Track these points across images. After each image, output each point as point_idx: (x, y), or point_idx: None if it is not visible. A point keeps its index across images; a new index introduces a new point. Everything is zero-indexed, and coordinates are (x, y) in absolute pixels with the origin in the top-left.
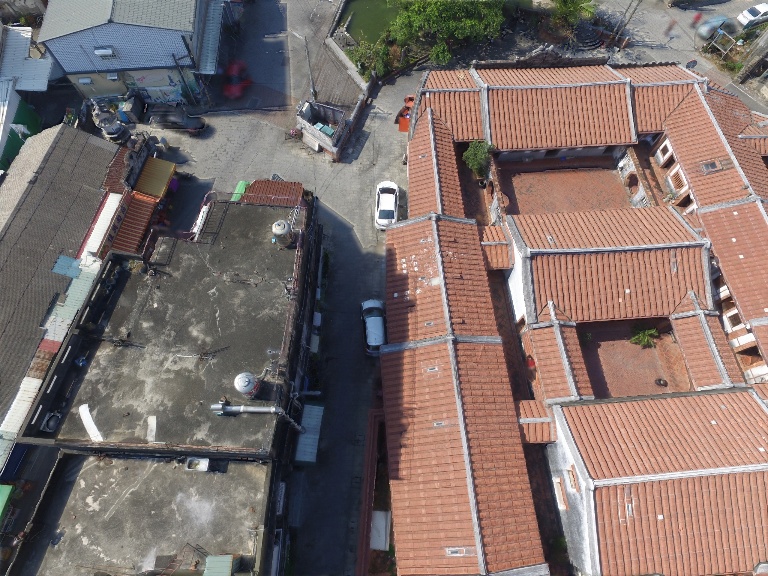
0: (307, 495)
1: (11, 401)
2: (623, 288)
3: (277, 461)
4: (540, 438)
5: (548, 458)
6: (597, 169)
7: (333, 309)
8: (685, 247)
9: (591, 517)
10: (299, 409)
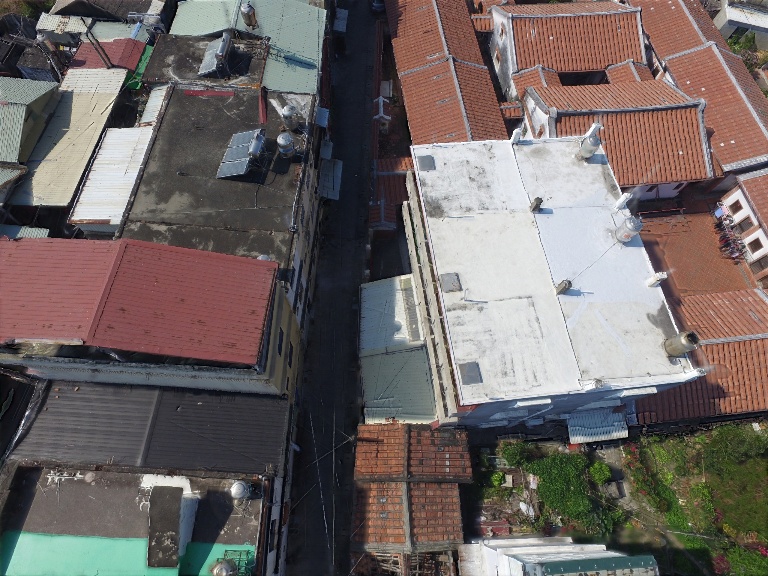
0: (339, 73)
1: (147, 9)
2: None
3: None
4: (484, 28)
5: (490, 52)
6: None
7: None
8: None
9: (511, 34)
10: None
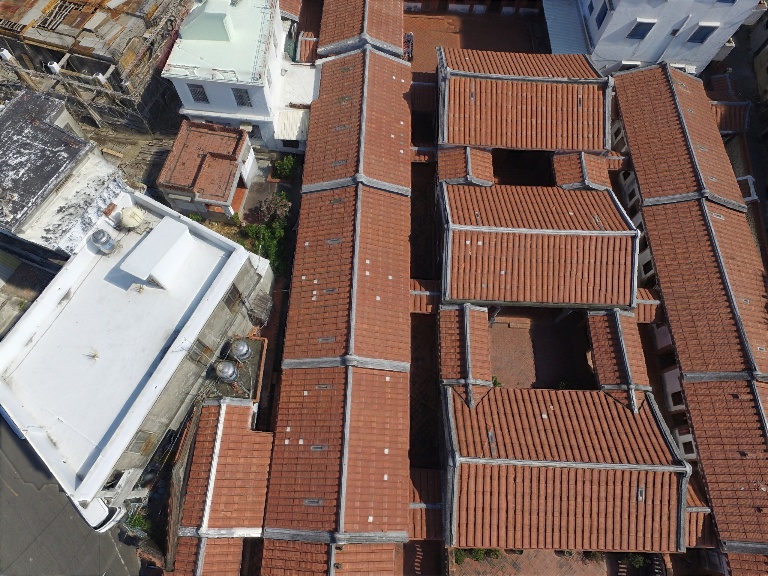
0: None
1: None
2: (550, 420)
3: None
4: None
5: None
6: None
7: None
8: None
9: None
10: None
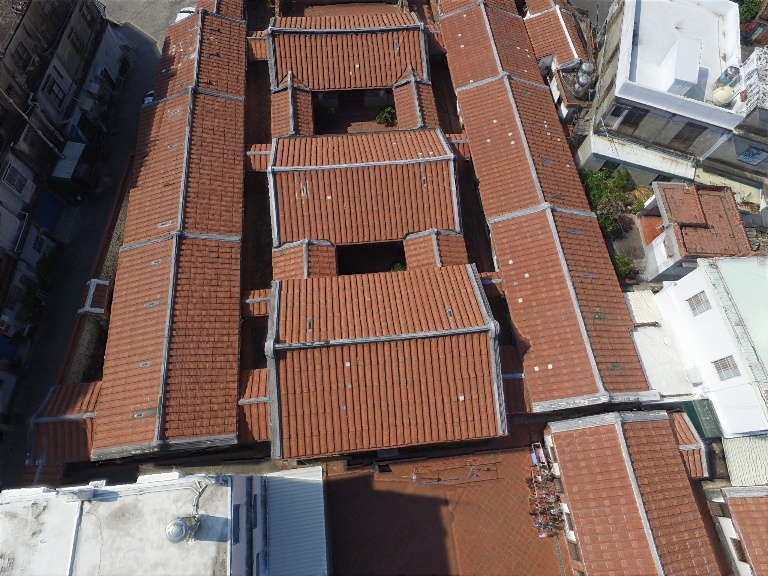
0: (78, 223)
1: None
2: (354, 64)
3: (6, 140)
4: (264, 167)
5: None
6: (381, 4)
7: (126, 100)
8: (405, 30)
9: (271, 195)
10: (59, 139)
